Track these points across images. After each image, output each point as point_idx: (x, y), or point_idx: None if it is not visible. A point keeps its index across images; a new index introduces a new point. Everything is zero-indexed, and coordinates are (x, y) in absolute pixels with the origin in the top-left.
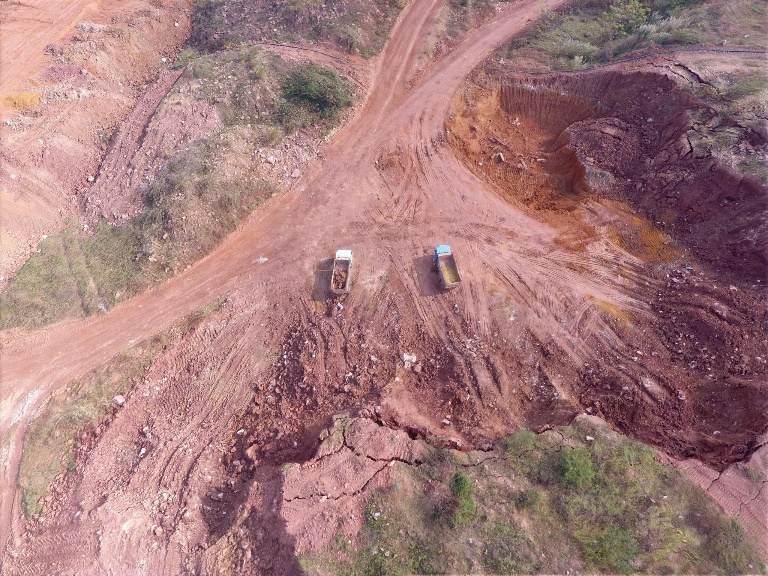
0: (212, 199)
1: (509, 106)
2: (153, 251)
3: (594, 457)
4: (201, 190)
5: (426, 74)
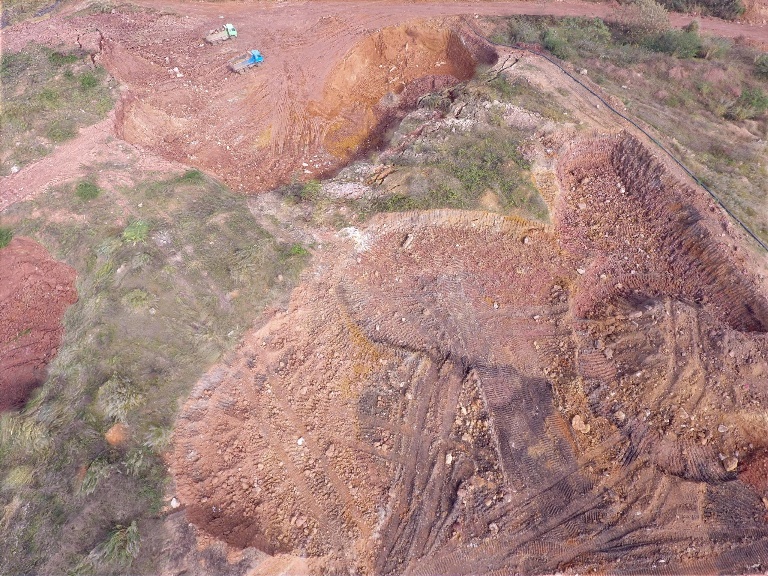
0: None
1: (450, 51)
2: None
3: (101, 92)
4: None
5: (434, 2)
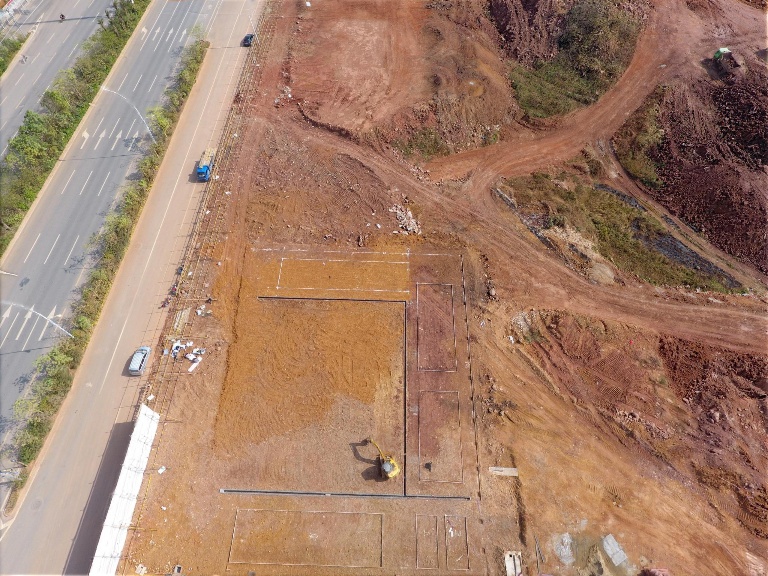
0: (615, 34)
1: None
2: (597, 68)
3: None
4: (609, 28)
5: None
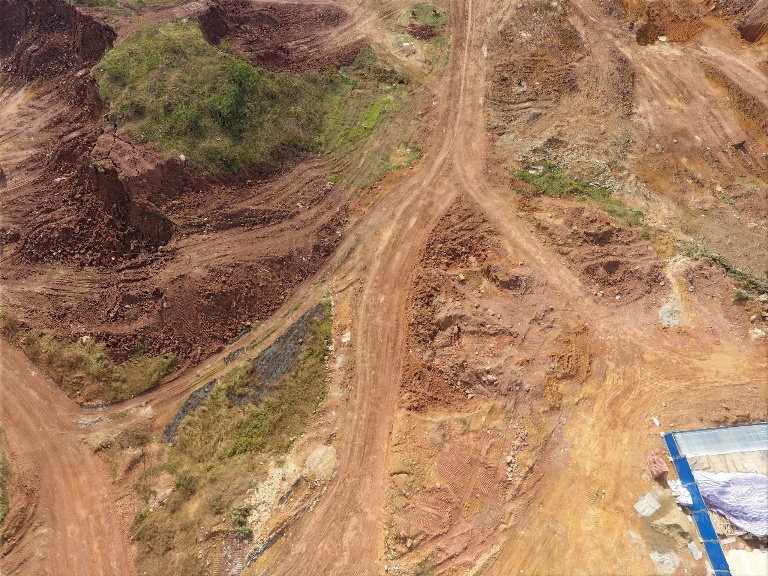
0: None
1: None
2: None
3: (112, 69)
4: None
5: None
